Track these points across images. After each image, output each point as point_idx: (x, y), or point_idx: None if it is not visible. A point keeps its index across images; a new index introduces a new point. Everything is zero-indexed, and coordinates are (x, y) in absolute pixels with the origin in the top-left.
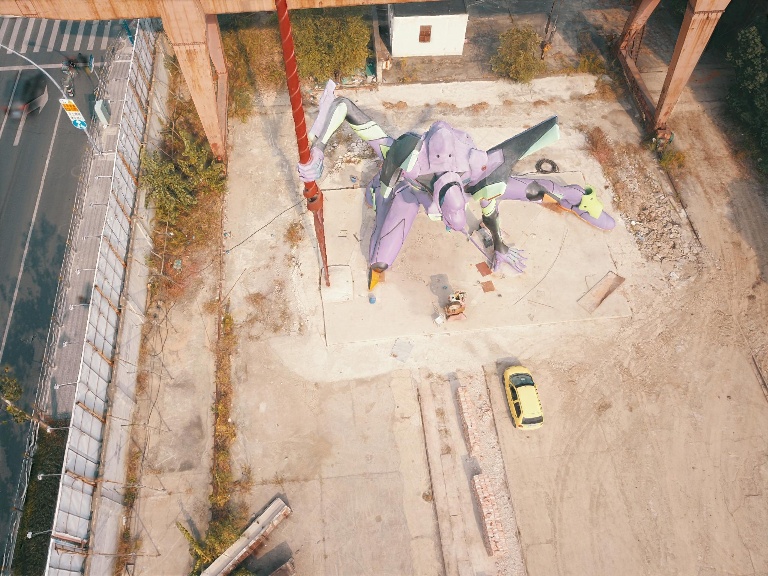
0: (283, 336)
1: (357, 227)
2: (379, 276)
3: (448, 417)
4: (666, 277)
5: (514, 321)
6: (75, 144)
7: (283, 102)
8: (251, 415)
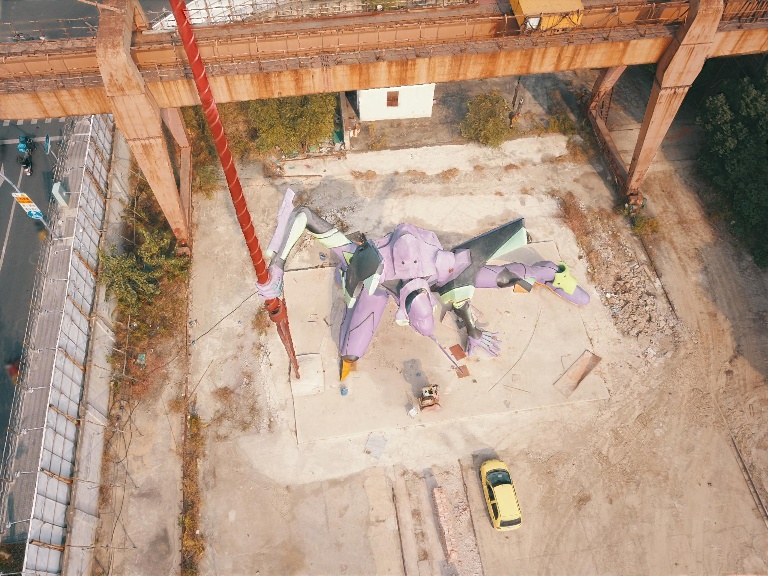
0: (252, 434)
1: (327, 310)
2: (350, 364)
3: (424, 518)
4: (643, 354)
5: (490, 409)
6: (33, 228)
7: (249, 174)
8: (220, 525)
